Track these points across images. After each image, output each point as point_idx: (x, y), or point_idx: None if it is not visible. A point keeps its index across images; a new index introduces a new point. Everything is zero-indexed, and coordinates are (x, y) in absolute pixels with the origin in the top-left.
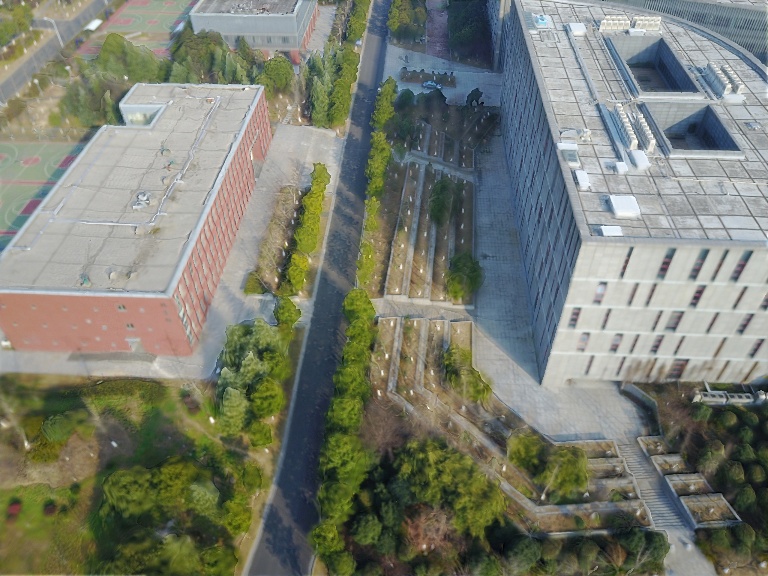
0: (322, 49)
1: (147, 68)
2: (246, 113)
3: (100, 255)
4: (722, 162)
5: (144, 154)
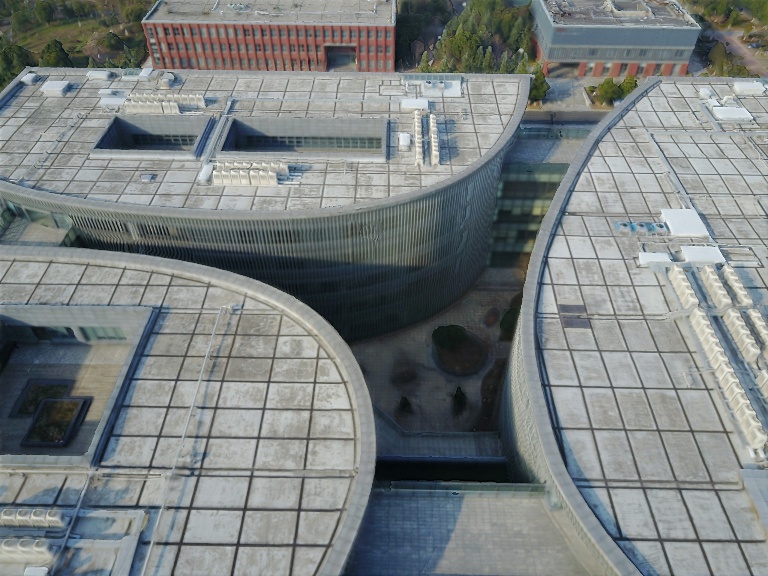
0: (587, 85)
1: (480, 7)
2: (345, 22)
3: (190, 5)
4: (92, 144)
5: (295, 2)
